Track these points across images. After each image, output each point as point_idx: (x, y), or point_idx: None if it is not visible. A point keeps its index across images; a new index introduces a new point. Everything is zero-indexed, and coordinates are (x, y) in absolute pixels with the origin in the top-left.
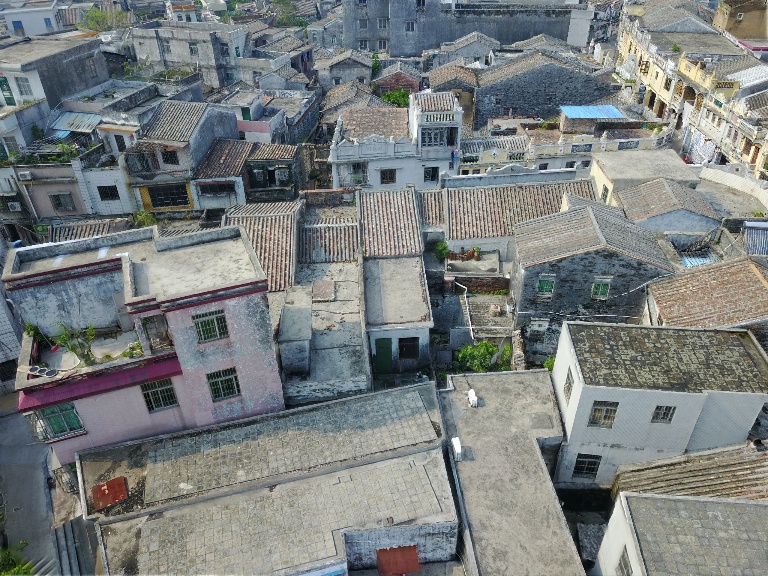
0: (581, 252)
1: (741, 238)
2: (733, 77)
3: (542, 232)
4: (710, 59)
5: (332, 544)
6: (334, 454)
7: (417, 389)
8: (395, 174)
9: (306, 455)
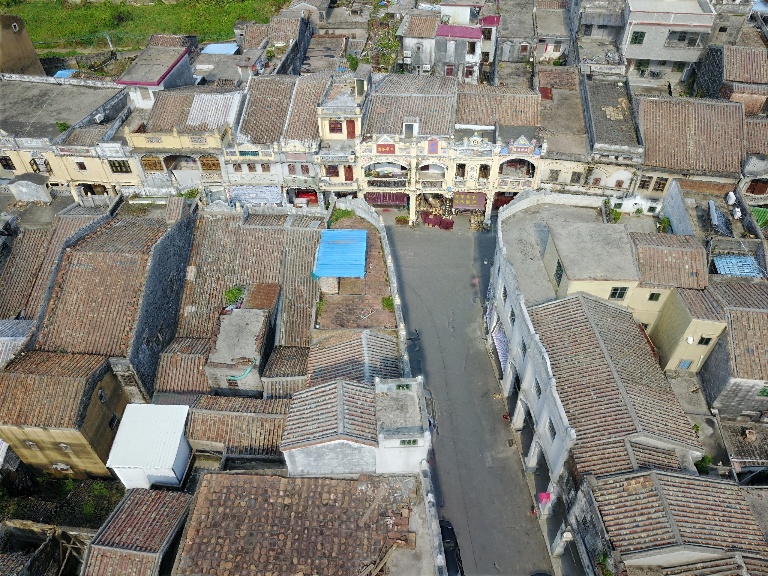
0: None
1: (712, 234)
2: (197, 121)
3: (761, 355)
4: (101, 115)
5: None
6: None
7: None
8: None
9: None
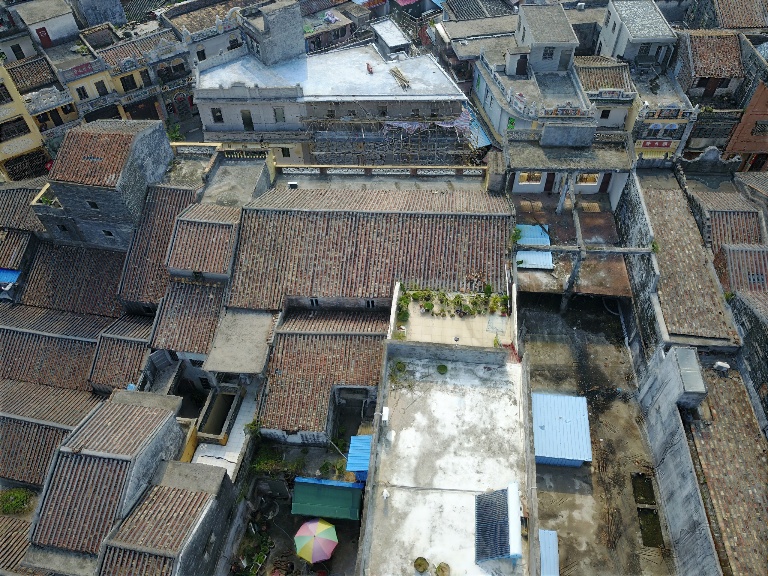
0: None
1: None
2: None
3: None
4: None
5: None
6: None
7: None
8: None
9: None
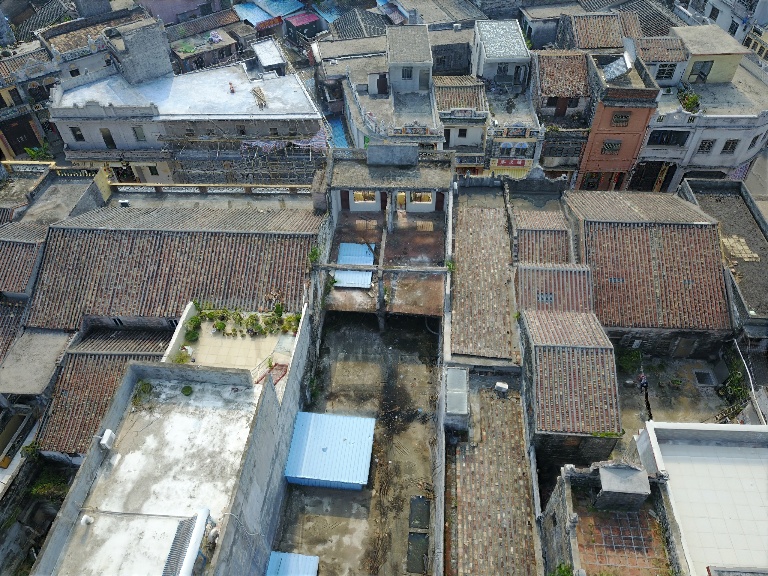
0: (568, 14)
1: None
2: None
3: None
4: None
5: (411, 8)
6: (445, 4)
7: (483, 16)
8: (718, 14)
9: (443, 0)
